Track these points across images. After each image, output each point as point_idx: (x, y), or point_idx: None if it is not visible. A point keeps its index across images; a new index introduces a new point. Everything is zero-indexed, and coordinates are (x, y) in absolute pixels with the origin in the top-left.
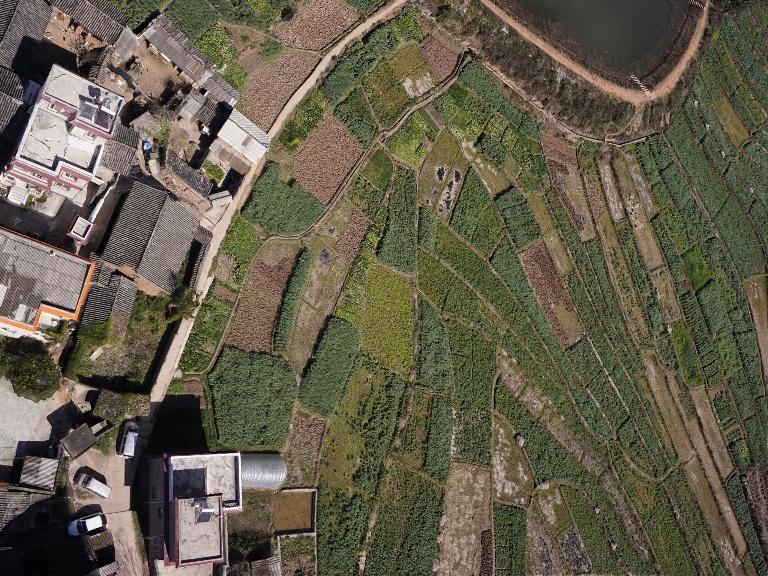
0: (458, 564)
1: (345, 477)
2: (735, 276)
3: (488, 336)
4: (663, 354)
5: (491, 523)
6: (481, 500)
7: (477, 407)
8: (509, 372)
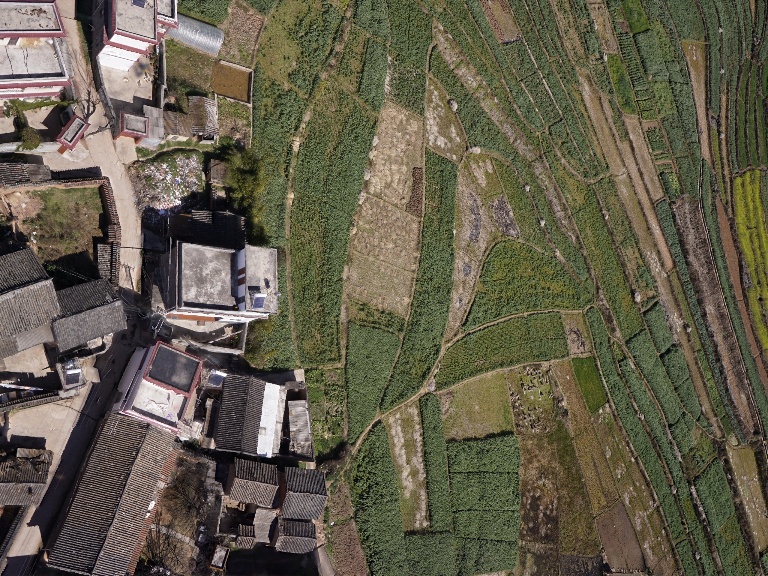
0: (389, 185)
1: (281, 72)
2: (674, 33)
3: (425, 6)
4: (598, 77)
5: (422, 163)
6: (413, 141)
7: (412, 64)
8: (445, 46)
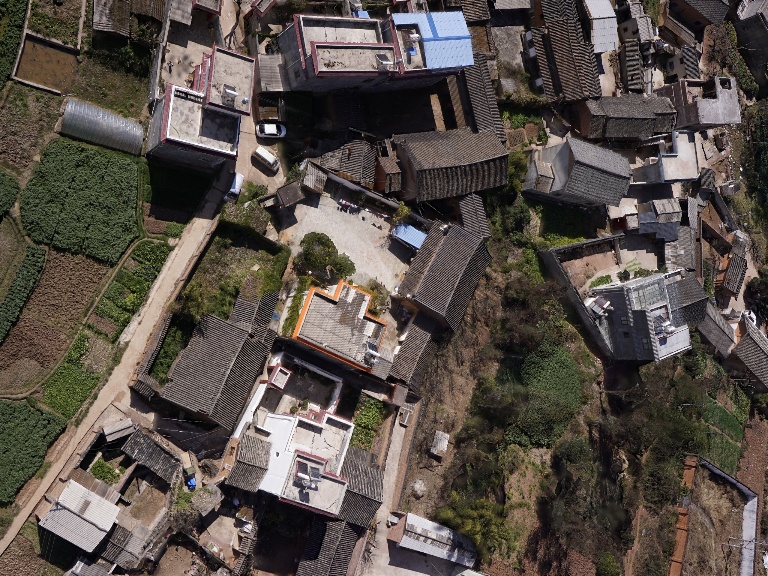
0: None
1: None
2: None
3: None
4: None
5: None
6: None
7: None
8: None
